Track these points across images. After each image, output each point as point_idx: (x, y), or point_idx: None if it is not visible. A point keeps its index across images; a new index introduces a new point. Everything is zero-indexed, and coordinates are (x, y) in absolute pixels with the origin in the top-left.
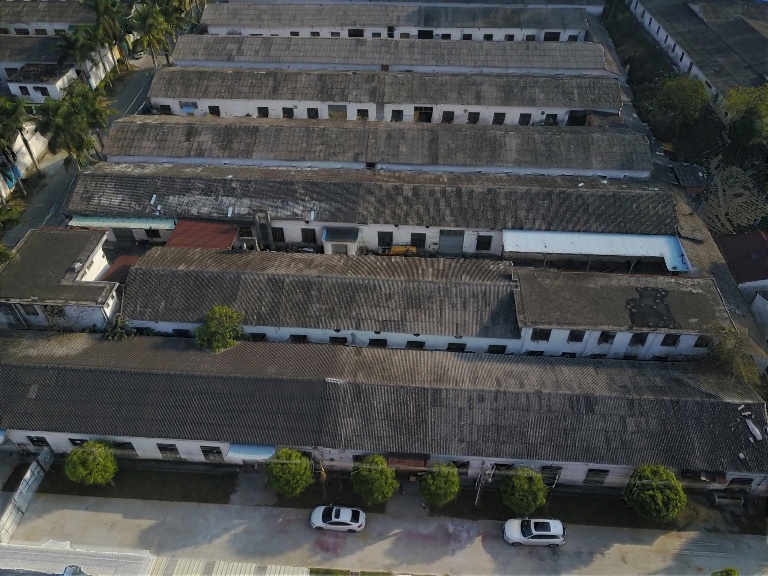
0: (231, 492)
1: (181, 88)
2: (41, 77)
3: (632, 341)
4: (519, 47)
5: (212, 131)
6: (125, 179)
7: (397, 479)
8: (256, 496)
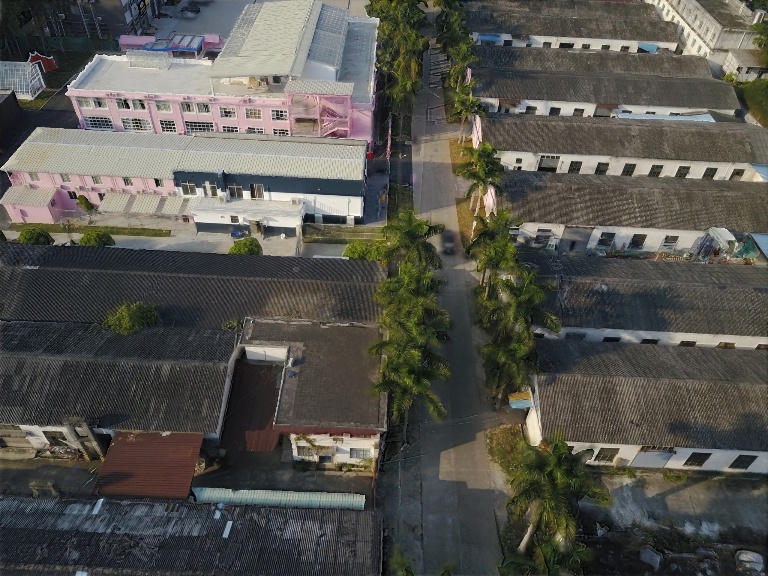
0: None
1: None
2: None
3: None
4: None
5: None
6: (283, 569)
7: None
8: None
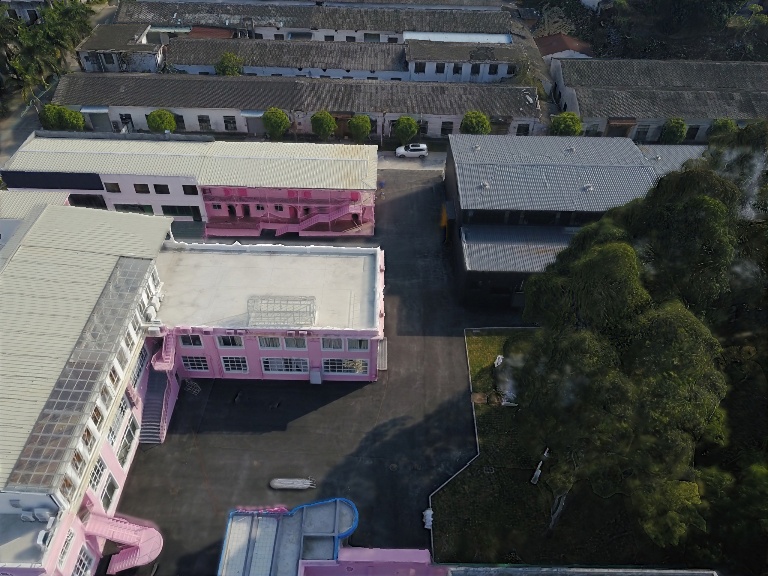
0: None
1: None
2: None
3: (472, 71)
4: None
5: None
6: (154, 5)
7: (336, 124)
8: None
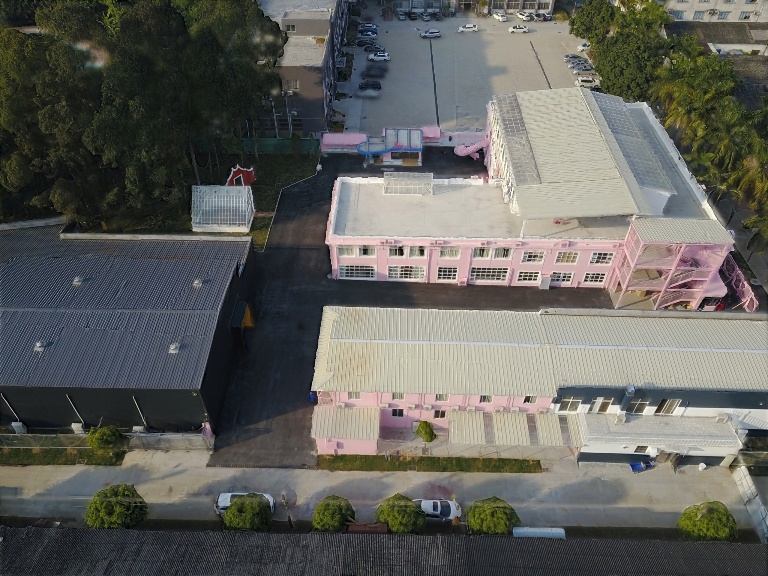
0: None
1: None
2: None
3: None
4: None
5: None
6: None
7: None
8: None
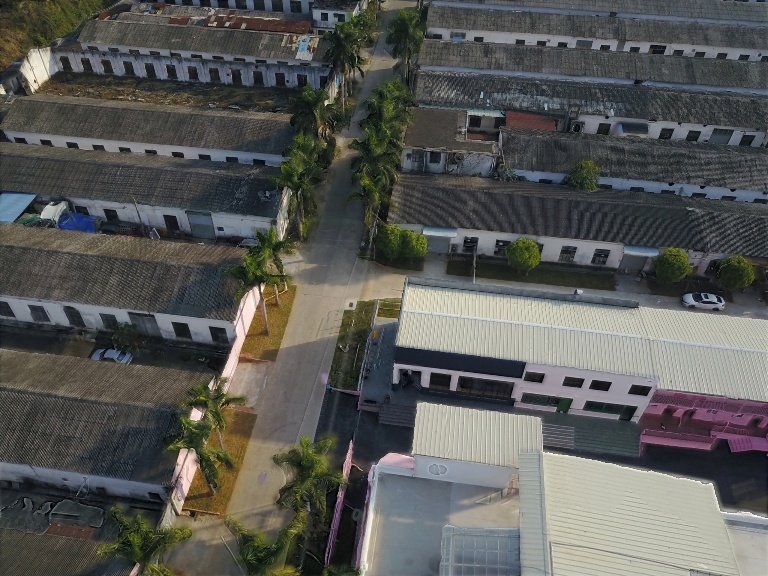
0: (614, 284)
1: (453, 21)
2: (340, 6)
3: None
4: (728, 3)
5: (505, 50)
6: (455, 79)
7: None
8: (634, 288)
